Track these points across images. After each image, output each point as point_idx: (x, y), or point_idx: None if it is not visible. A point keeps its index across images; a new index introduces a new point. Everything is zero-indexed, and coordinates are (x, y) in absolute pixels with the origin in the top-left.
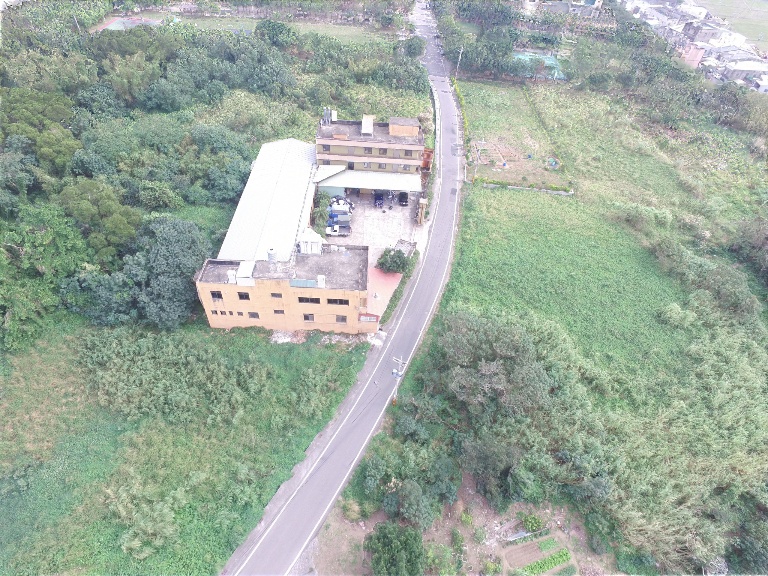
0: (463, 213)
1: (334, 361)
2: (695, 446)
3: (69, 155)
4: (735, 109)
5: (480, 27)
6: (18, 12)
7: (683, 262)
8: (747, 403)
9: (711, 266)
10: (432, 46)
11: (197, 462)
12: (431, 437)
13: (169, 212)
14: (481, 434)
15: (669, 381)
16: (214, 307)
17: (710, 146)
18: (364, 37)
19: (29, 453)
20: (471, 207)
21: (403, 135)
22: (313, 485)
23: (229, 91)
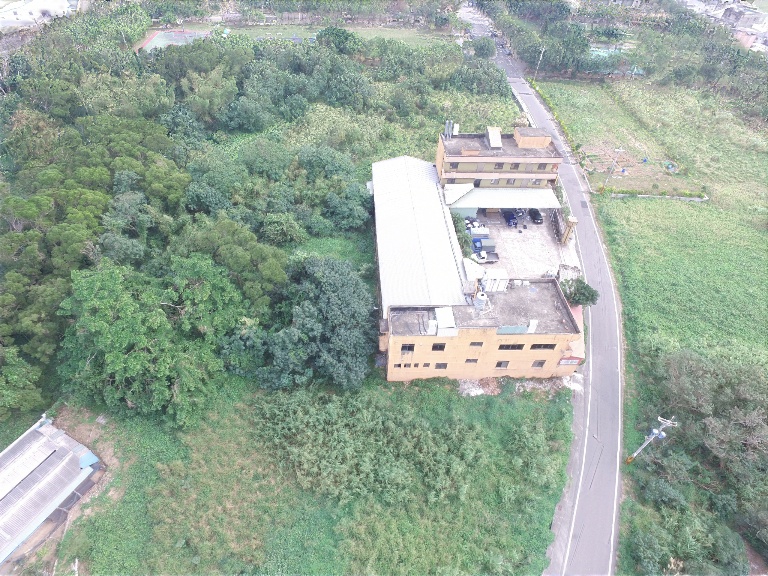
0: (604, 228)
1: (541, 413)
2: None
3: (180, 190)
4: None
5: None
6: (56, 30)
7: None
8: None
9: None
10: None
11: (435, 552)
12: (685, 500)
13: (295, 247)
14: (747, 495)
15: None
16: (400, 360)
17: None
18: (421, 39)
19: (237, 555)
20: (610, 221)
21: (533, 147)
22: (578, 572)
23: (311, 106)
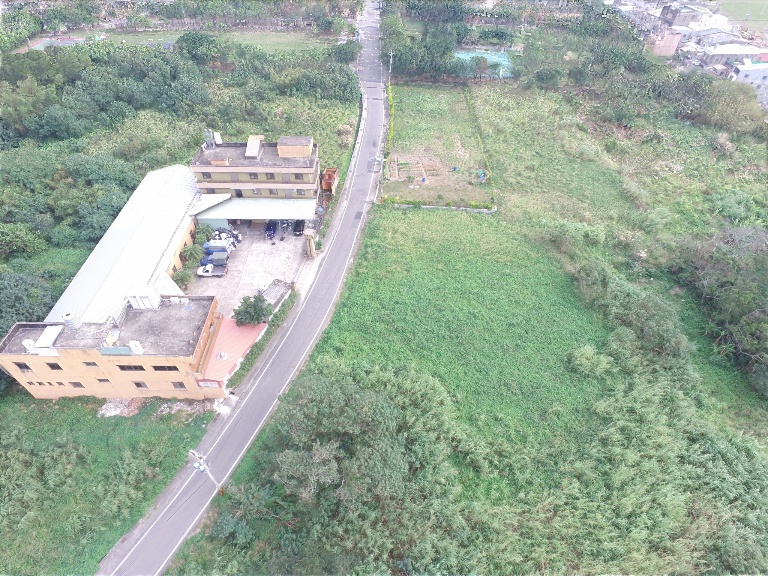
0: (363, 241)
1: (165, 438)
2: (581, 543)
3: None
4: (701, 100)
5: (425, 25)
6: None
7: None
8: (656, 480)
9: (640, 295)
10: (374, 49)
11: None
12: (257, 538)
13: (27, 257)
14: (313, 535)
15: (566, 450)
16: (27, 378)
17: (668, 145)
18: (302, 44)
19: None
20: (374, 233)
21: (294, 156)
22: None
23: (132, 113)
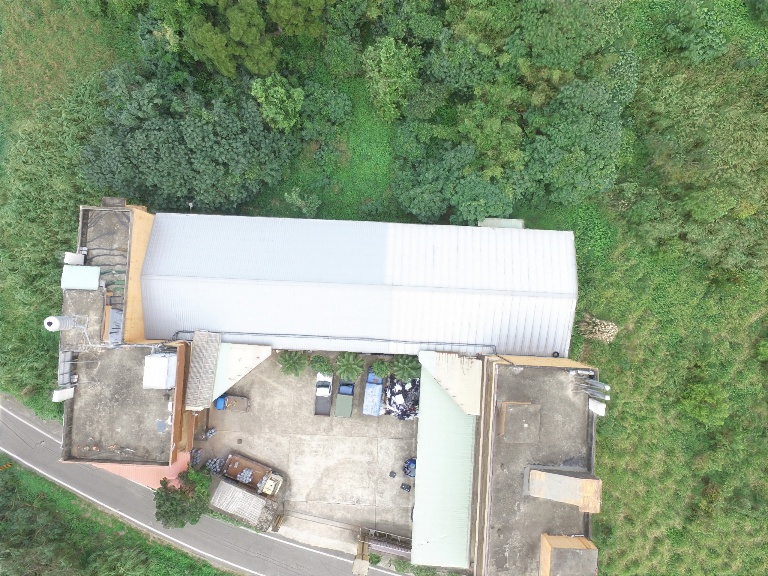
0: None
1: None
2: None
3: None
4: None
5: None
6: None
7: None
8: None
9: None
10: None
11: None
12: None
13: None
14: None
15: None
16: None
17: None
18: None
19: None
20: None
21: (542, 567)
22: None
23: None
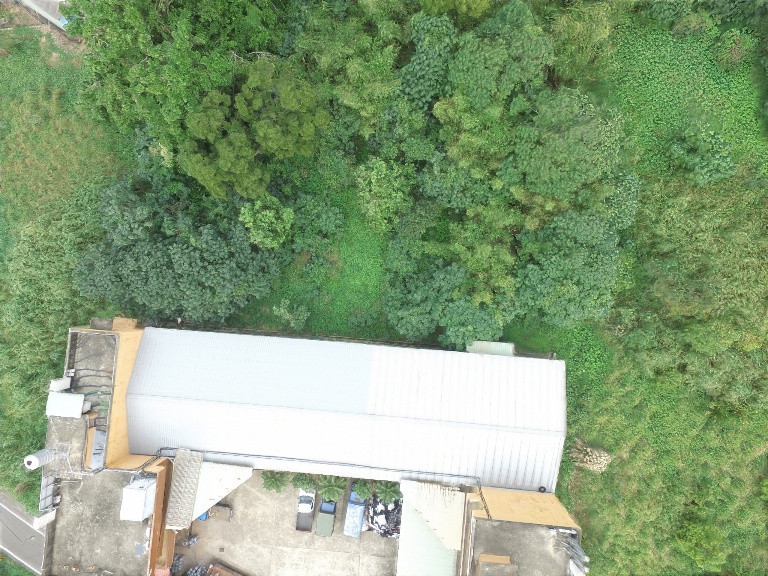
0: None
1: None
2: None
3: (445, 5)
4: None
5: None
6: None
7: None
8: None
9: None
10: None
11: None
12: None
13: None
14: None
15: None
16: None
17: None
18: None
19: None
20: None
21: None
22: None
23: None
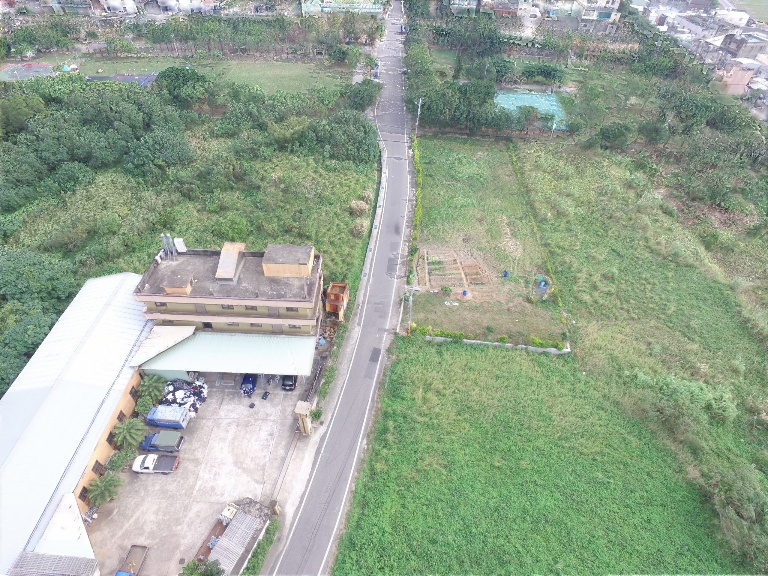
0: (382, 405)
1: None
2: None
3: None
4: None
5: None
6: None
7: (767, 533)
8: None
9: None
10: (396, 86)
11: None
12: None
13: None
14: None
15: None
16: None
17: None
18: (310, 78)
19: None
20: (397, 391)
21: (286, 275)
22: None
23: (88, 177)
